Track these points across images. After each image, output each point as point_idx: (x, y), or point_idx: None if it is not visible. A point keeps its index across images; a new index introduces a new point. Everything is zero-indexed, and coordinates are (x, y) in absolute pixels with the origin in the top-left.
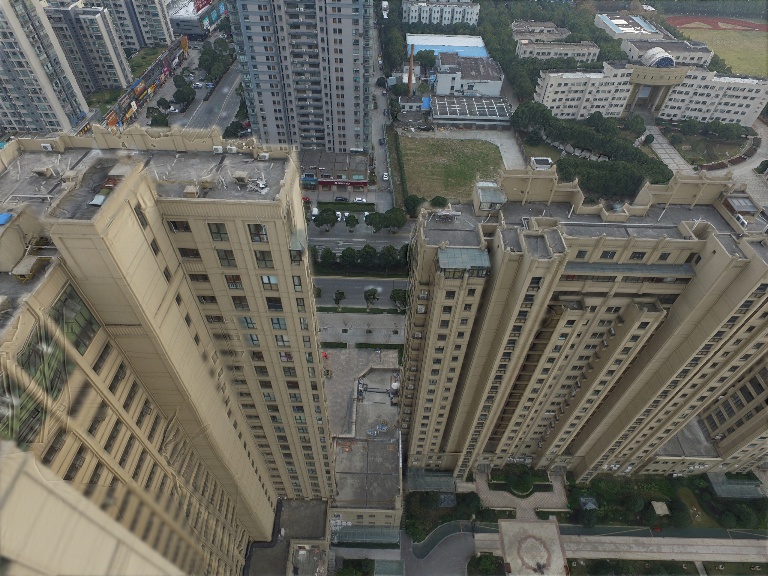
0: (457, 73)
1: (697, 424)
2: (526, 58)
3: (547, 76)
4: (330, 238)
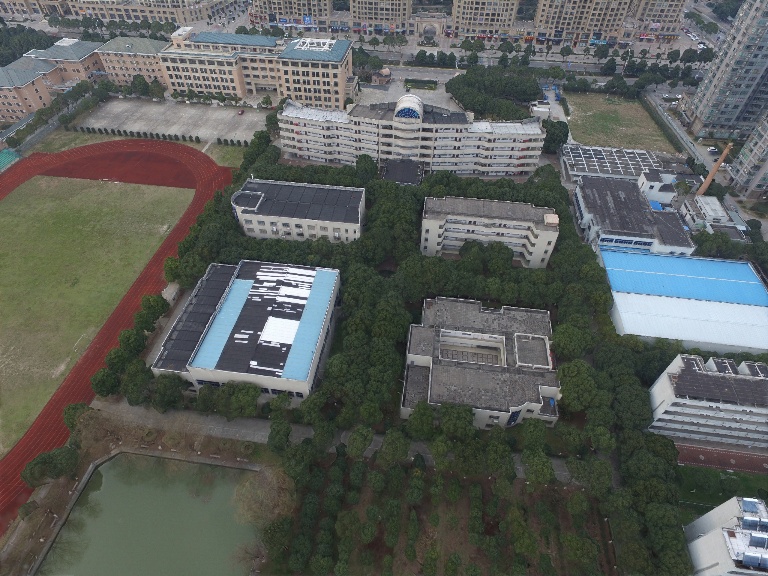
0: (648, 174)
1: (515, 24)
2: None
3: None
4: (681, 88)
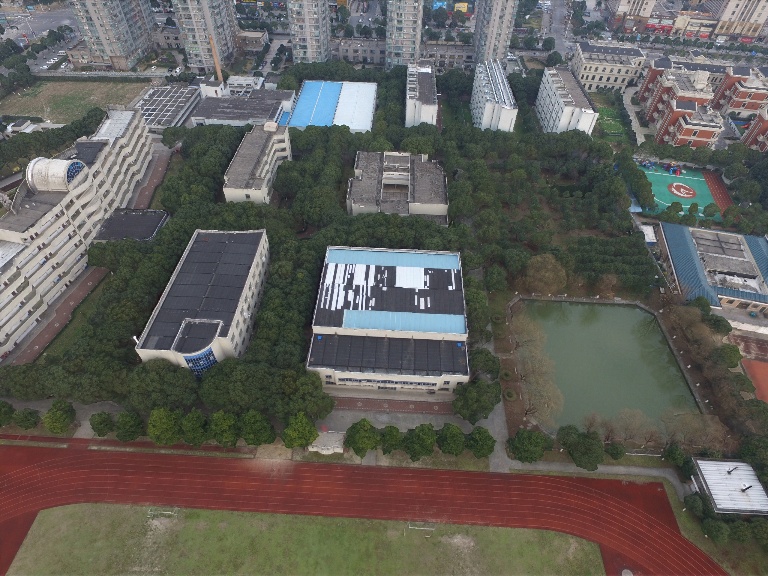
0: None
1: None
2: (224, 126)
3: (119, 108)
4: None
